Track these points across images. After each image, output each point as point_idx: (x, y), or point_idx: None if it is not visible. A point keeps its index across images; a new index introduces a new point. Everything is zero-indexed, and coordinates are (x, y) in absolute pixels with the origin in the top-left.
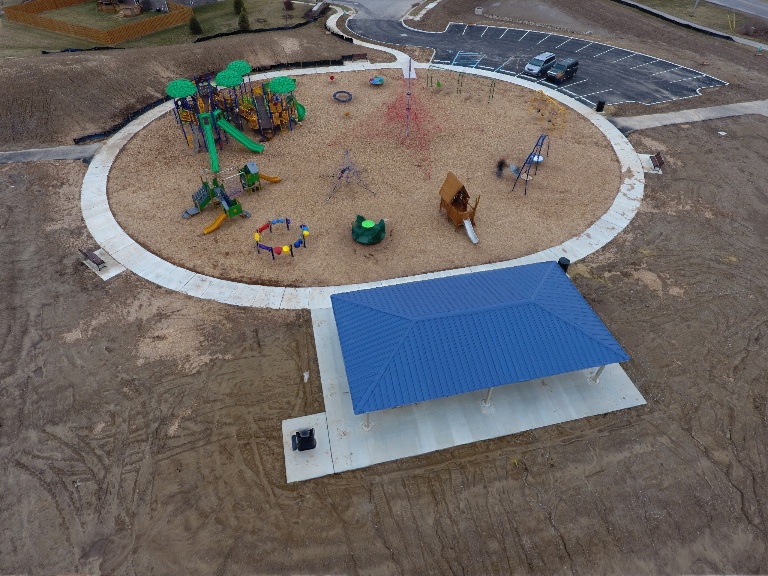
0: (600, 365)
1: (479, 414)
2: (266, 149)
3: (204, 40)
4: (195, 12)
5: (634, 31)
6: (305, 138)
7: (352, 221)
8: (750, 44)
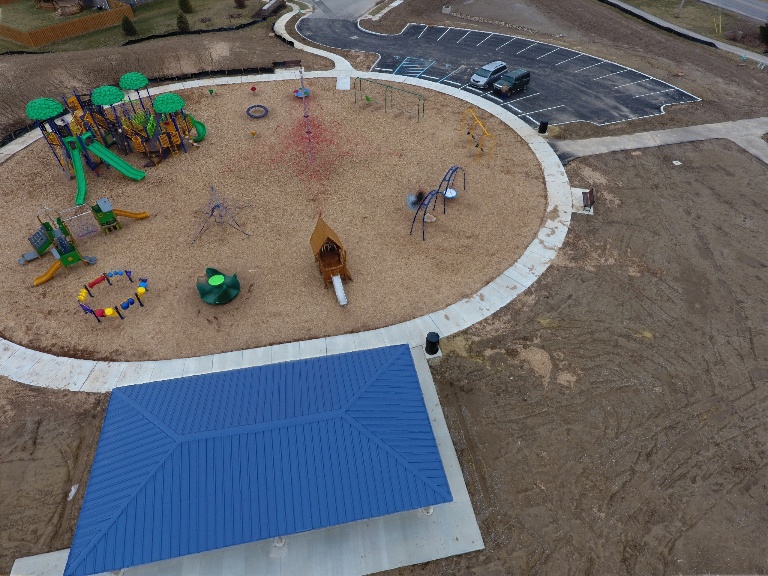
0: (410, 509)
1: (264, 558)
2: (149, 176)
3: (135, 42)
4: (138, 10)
5: (610, 34)
6: (197, 163)
7: None
8: (735, 51)
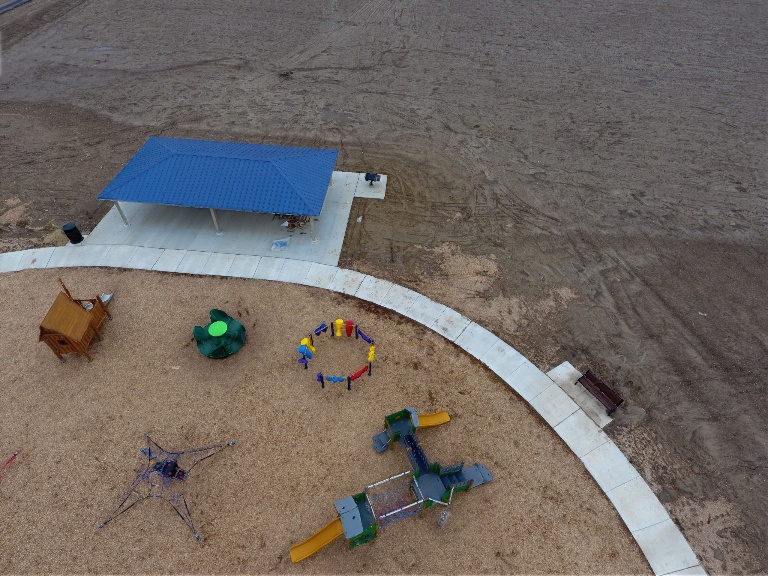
0: None
1: None
2: None
3: None
4: None
5: None
6: None
7: (237, 333)
8: None
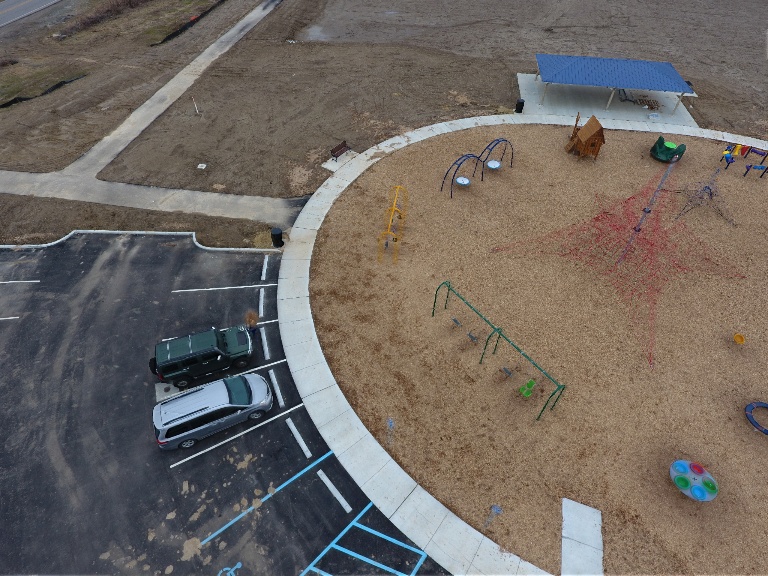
0: None
1: None
2: None
3: None
4: None
5: None
6: None
7: None
8: None
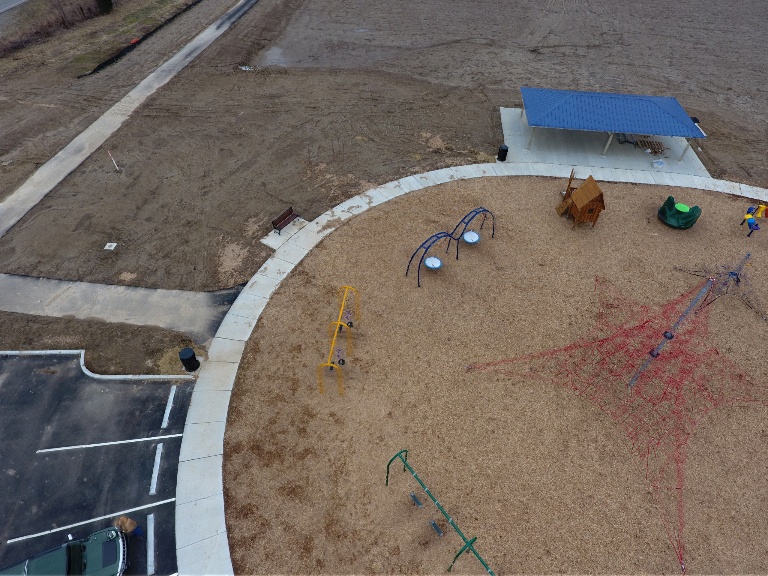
0: None
1: None
2: None
3: None
4: None
5: None
6: None
7: None
8: None
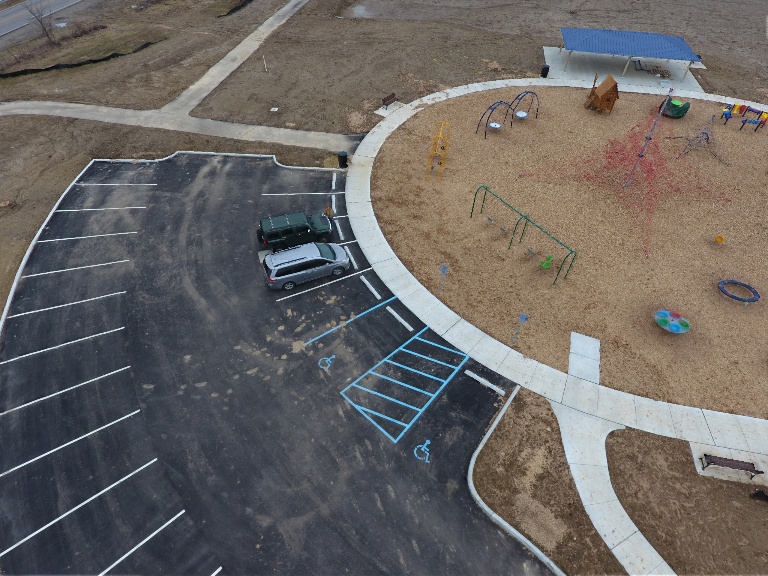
0: None
1: None
2: None
3: None
4: None
5: None
6: None
7: None
8: None
